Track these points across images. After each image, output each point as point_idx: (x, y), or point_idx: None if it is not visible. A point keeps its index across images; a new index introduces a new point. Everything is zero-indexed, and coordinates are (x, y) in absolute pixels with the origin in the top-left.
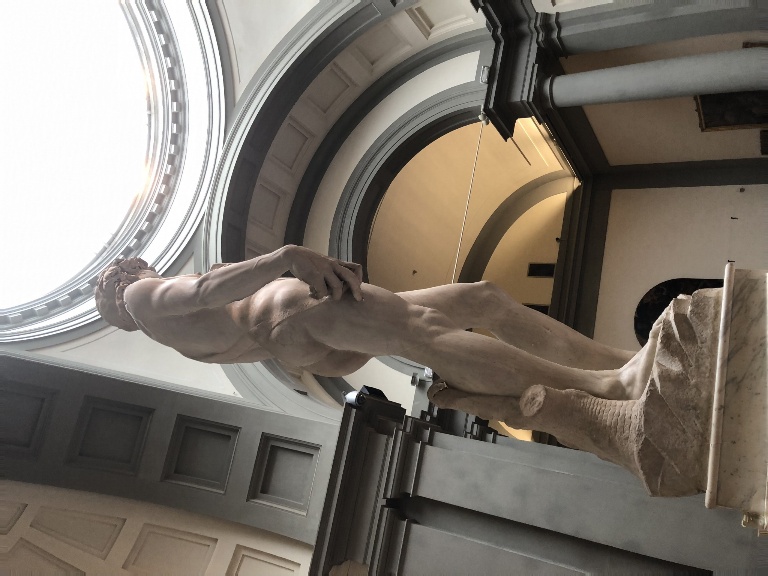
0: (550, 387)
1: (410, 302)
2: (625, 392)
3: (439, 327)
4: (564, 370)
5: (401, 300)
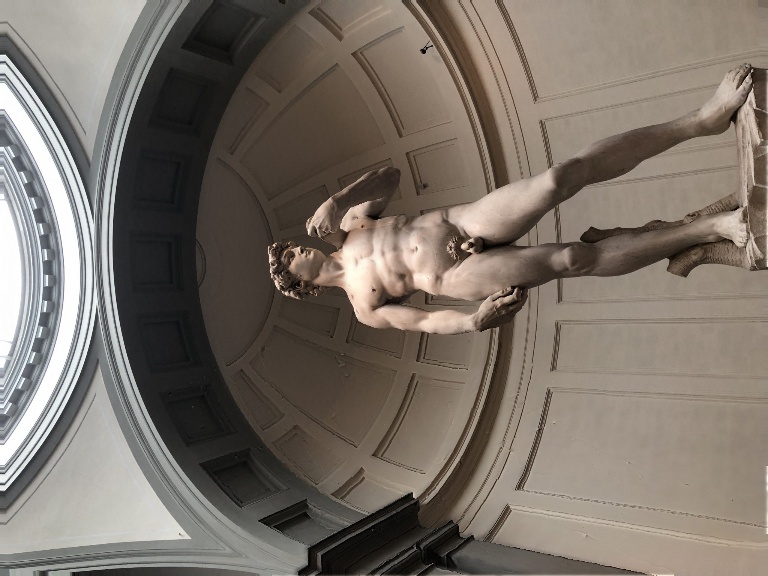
0: (682, 264)
1: (519, 225)
2: (726, 238)
3: (586, 269)
4: (680, 244)
5: (544, 269)
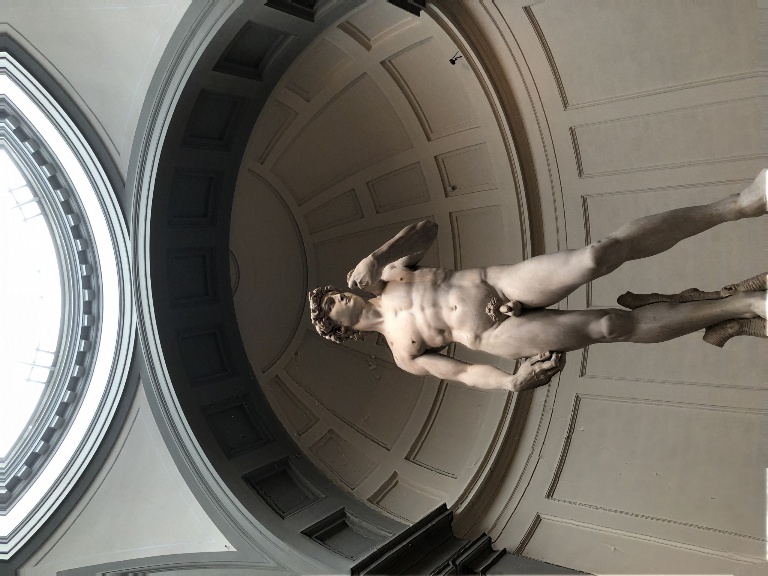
0: (718, 336)
1: (558, 294)
2: None
3: None
4: None
5: (582, 337)
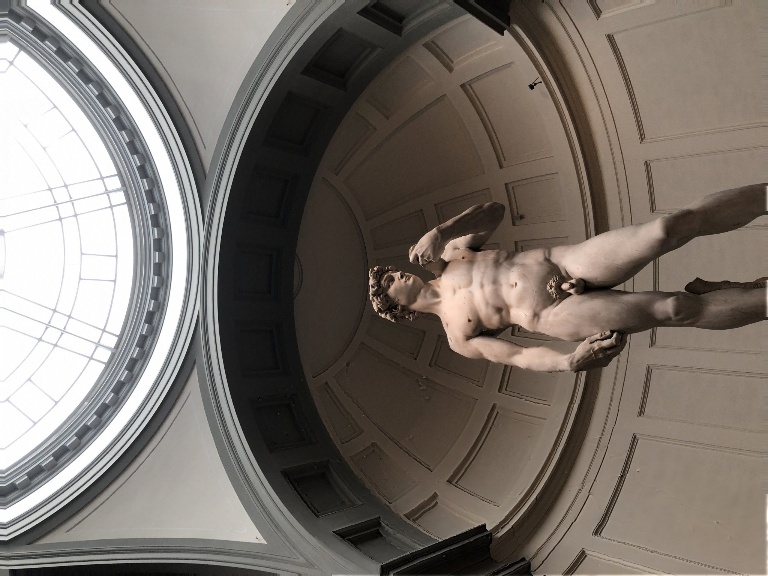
0: None
1: (624, 270)
2: None
3: (690, 321)
4: None
5: (646, 316)
